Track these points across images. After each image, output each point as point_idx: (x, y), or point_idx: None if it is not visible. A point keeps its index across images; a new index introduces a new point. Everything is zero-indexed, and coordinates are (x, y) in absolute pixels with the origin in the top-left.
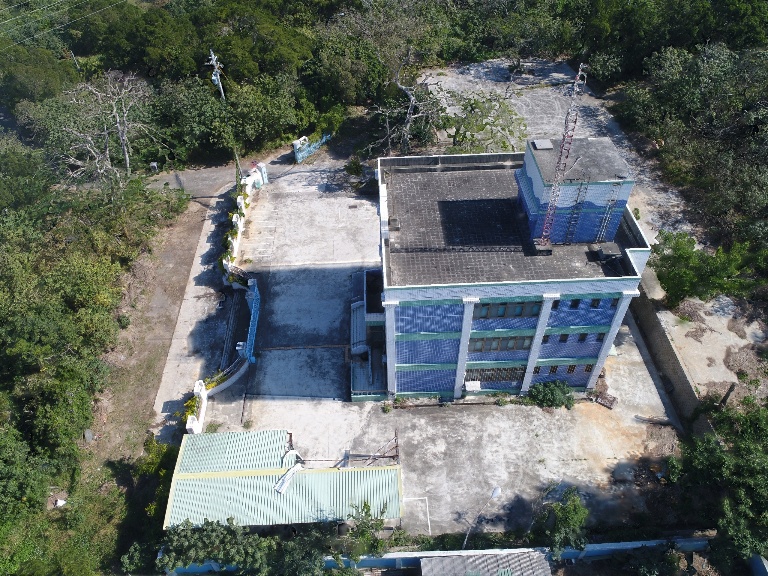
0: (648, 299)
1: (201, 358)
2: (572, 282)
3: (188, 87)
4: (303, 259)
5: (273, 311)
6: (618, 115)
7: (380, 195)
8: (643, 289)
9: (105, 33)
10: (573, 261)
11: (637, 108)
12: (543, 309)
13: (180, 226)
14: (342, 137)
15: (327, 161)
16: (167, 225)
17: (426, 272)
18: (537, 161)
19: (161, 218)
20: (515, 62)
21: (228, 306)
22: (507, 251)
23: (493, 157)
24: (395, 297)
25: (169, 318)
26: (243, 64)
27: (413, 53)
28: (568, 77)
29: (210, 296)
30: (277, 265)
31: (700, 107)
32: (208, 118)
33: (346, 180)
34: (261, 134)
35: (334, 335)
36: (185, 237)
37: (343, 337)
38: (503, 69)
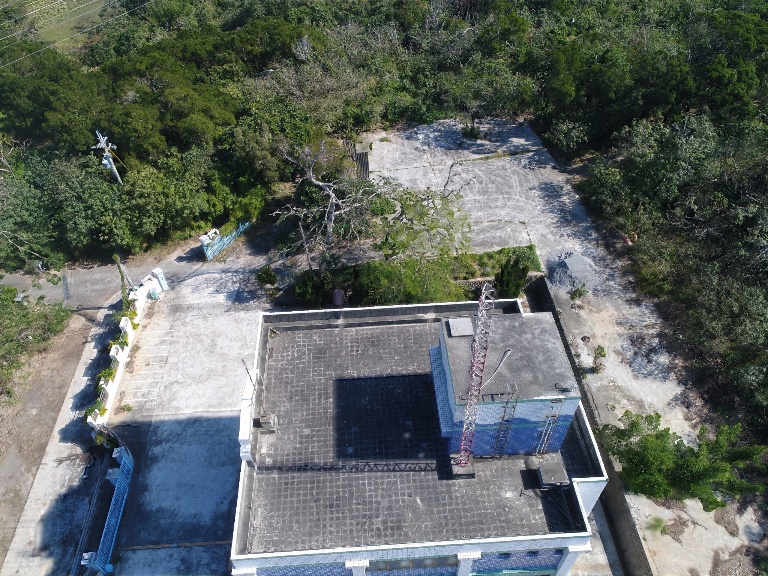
0: (615, 472)
1: (48, 559)
2: (496, 542)
3: (83, 166)
4: (195, 404)
5: (147, 486)
6: (584, 197)
7: (243, 395)
8: (609, 455)
9: (5, 91)
10: (503, 488)
11: (605, 195)
12: (461, 563)
13: (55, 352)
14: (264, 224)
15: (242, 258)
16: (39, 350)
17: (301, 511)
18: (449, 359)
19: (33, 341)
20: (469, 125)
21: (95, 474)
22: (415, 470)
23: (410, 309)
24: (249, 565)
25: (18, 494)
26: (147, 138)
27: (351, 116)
28: (529, 143)
29: (75, 459)
30: (161, 414)
31: (679, 194)
32: (96, 212)
33: (261, 285)
34: (164, 226)
35: (219, 525)
36: (58, 368)
37: (230, 528)
38: (456, 133)
